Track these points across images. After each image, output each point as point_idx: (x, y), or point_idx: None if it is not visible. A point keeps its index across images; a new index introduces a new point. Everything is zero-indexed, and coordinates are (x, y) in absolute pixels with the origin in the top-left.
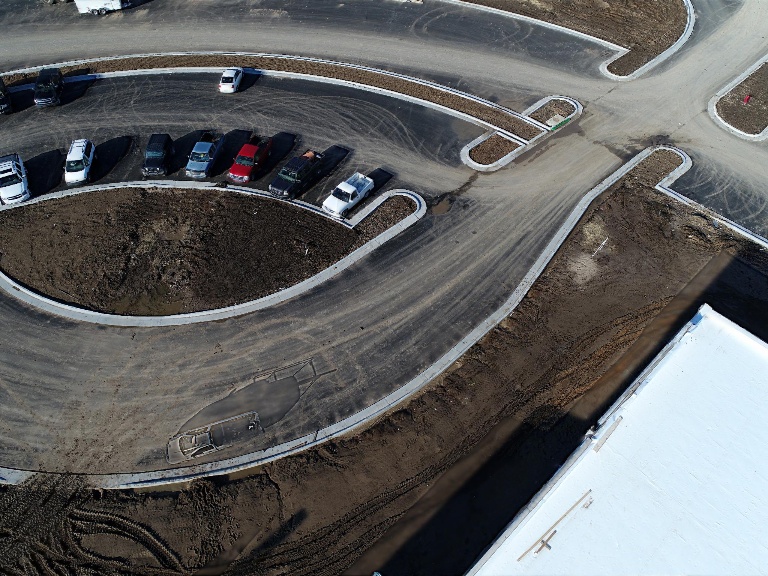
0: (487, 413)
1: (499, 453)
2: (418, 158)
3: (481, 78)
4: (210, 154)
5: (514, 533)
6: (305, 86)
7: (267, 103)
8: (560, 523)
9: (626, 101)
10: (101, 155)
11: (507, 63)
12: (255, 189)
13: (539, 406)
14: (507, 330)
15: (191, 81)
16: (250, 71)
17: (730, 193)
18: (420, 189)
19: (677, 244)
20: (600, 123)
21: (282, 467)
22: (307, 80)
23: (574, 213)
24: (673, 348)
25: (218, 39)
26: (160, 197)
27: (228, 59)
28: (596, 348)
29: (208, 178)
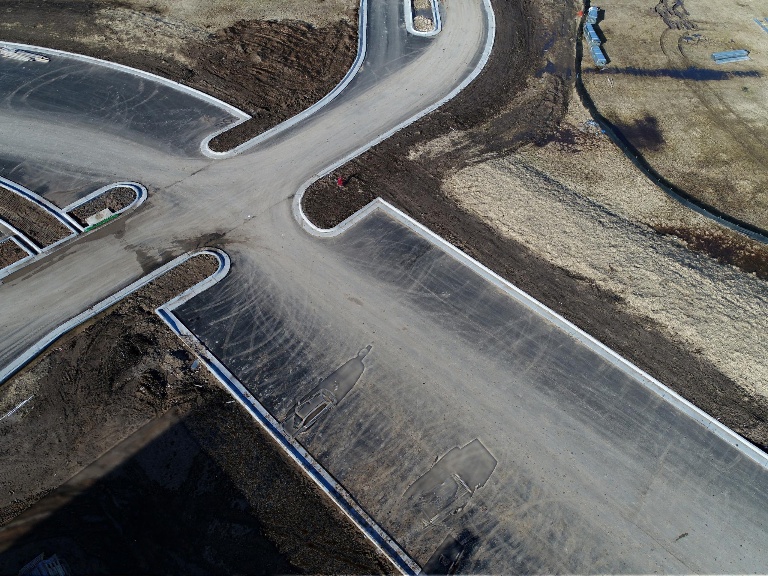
0: None
1: None
2: None
3: (47, 161)
4: None
5: None
6: None
7: None
8: None
9: (205, 186)
10: None
11: (94, 139)
12: None
13: None
14: None
15: None
16: None
17: (246, 316)
18: None
19: (117, 401)
20: (153, 219)
21: None
22: None
23: (22, 357)
24: None
25: None
26: None
27: None
28: None
29: None
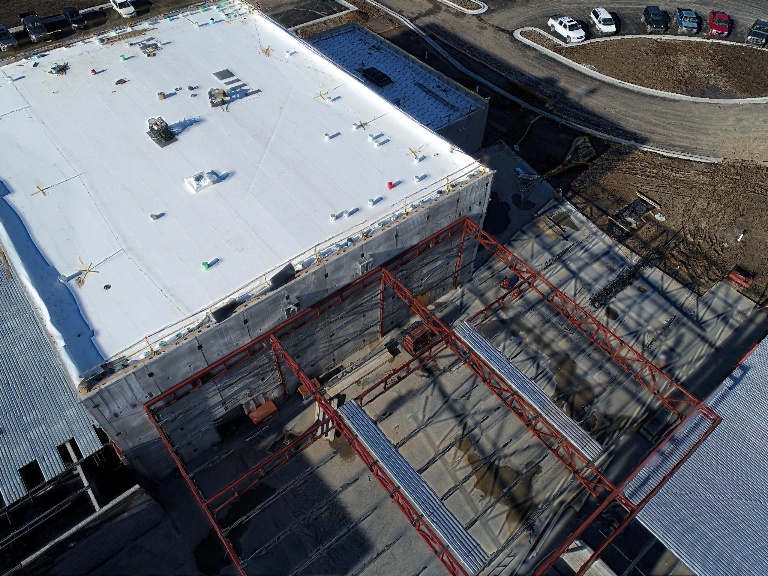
0: None
1: None
2: None
3: None
4: None
5: None
6: None
7: None
8: None
9: None
10: None
11: None
12: (730, 41)
13: None
14: None
15: None
16: None
17: None
18: None
19: None
20: None
21: None
22: None
23: None
24: None
25: None
26: (668, 44)
27: None
28: None
29: (693, 35)
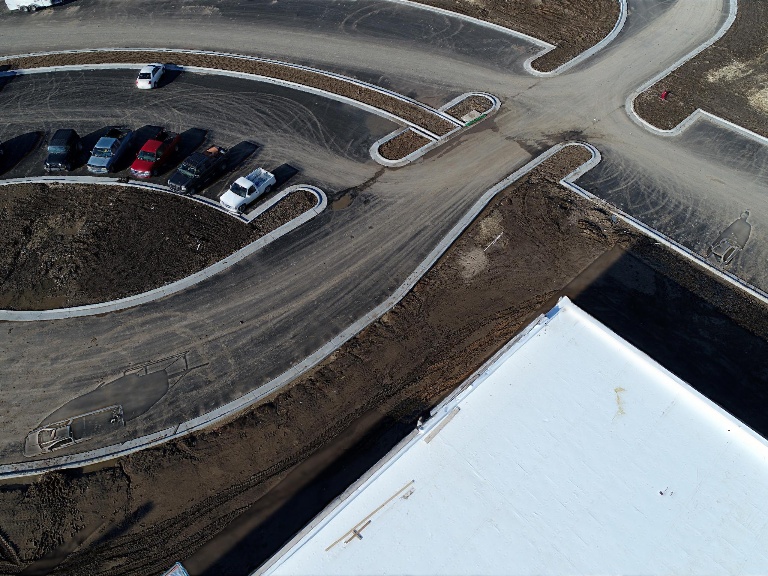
0: (352, 406)
1: (356, 446)
2: (327, 154)
3: (403, 74)
4: (113, 149)
5: (321, 523)
6: (225, 82)
7: (184, 99)
8: (376, 513)
9: (545, 97)
10: (8, 151)
11: (432, 59)
12: (156, 184)
13: (405, 399)
14: (387, 324)
15: (111, 77)
16: (172, 67)
17: (634, 188)
18: (324, 184)
19: (571, 239)
20: (516, 119)
21: (137, 460)
22: (228, 76)
23: (474, 208)
24: (520, 340)
25: (145, 36)
26: (60, 192)
27: (152, 55)
28: (472, 342)
29: (111, 173)
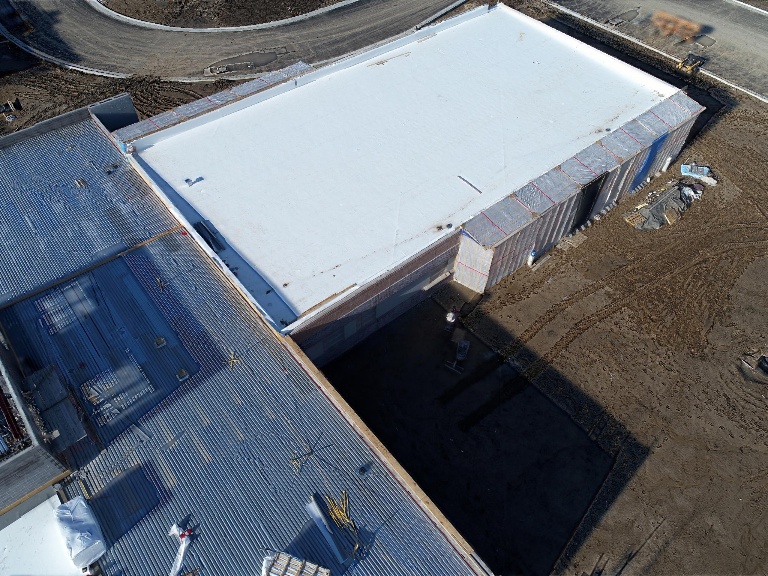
0: None
1: None
2: None
3: None
4: None
5: (365, 52)
6: None
7: None
8: (391, 59)
9: None
10: None
11: None
12: None
13: None
14: None
15: None
16: None
17: None
18: None
19: None
20: None
21: None
22: None
23: None
24: (472, 10)
25: None
26: None
27: None
28: None
29: None
